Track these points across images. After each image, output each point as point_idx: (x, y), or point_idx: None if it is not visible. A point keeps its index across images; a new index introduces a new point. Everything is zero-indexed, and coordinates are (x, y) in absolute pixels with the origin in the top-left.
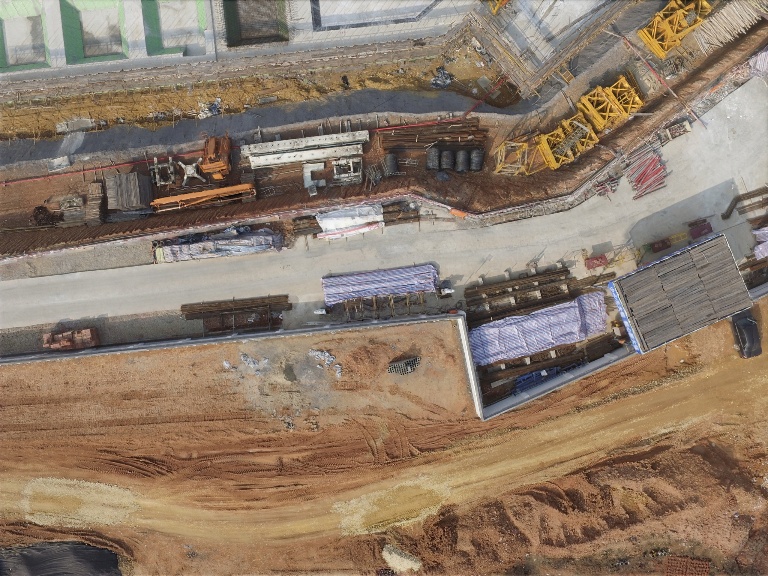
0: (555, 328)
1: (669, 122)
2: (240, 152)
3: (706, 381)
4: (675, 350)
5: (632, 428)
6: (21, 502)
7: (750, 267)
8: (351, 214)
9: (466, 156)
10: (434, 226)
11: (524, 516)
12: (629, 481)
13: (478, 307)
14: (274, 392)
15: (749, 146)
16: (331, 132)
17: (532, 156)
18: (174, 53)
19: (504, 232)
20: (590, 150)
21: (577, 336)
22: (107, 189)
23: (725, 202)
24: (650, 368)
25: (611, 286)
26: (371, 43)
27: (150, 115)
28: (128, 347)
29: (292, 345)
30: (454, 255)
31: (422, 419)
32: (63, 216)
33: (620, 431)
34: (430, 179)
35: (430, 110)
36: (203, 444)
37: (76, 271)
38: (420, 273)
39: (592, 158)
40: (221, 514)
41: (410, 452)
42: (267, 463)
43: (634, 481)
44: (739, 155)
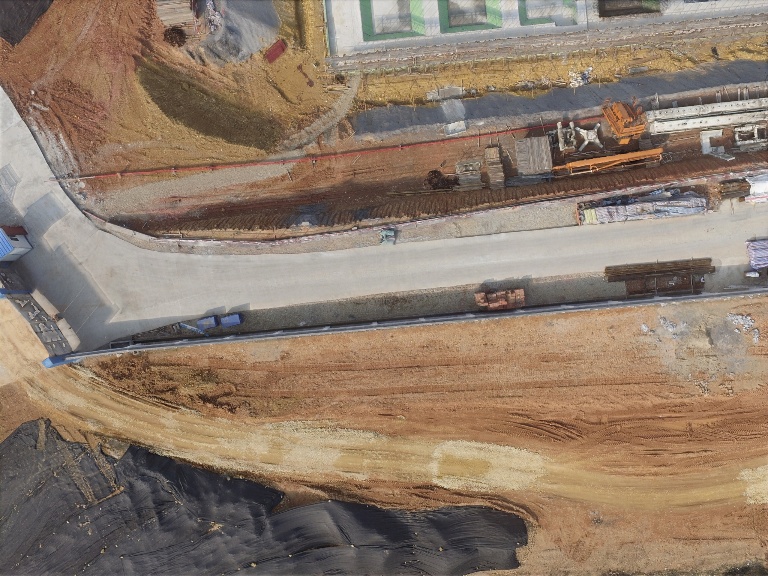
0: None
1: None
2: (637, 118)
3: None
4: None
5: None
6: (429, 465)
7: None
8: None
9: None
10: None
11: None
12: None
13: None
14: (690, 356)
15: None
16: (728, 99)
17: None
18: (546, 23)
19: None
20: None
21: None
22: (517, 152)
23: None
24: None
25: None
26: (741, 15)
27: (519, 84)
28: (569, 307)
29: (710, 309)
30: None
31: None
32: (458, 180)
33: None
34: None
35: None
36: (615, 408)
37: (501, 232)
38: None
39: None
40: (629, 480)
41: None
42: (676, 428)
43: None
44: None
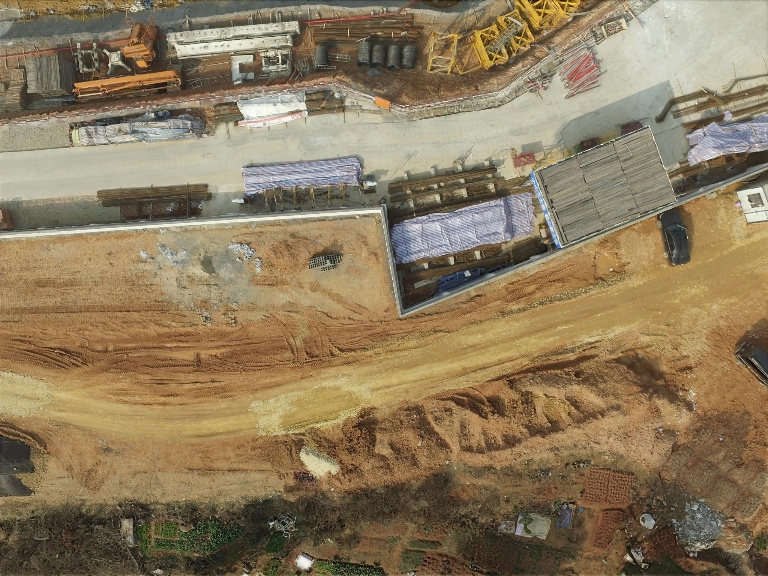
0: (480, 227)
1: (604, 18)
2: (167, 42)
3: (634, 290)
4: (605, 258)
5: (557, 336)
6: None
7: (683, 173)
8: (273, 101)
9: (397, 51)
10: (359, 118)
11: (444, 421)
12: (551, 388)
13: (403, 204)
14: (192, 285)
15: (686, 47)
16: None
17: (467, 55)
18: None
19: (431, 127)
20: (526, 51)
21: (502, 236)
22: (27, 72)
23: (660, 105)
24: (578, 275)
25: (532, 177)
26: None
27: (81, 7)
28: (39, 228)
29: (211, 237)
30: (379, 149)
31: (343, 318)
32: None
33: (545, 338)
34: (360, 73)
35: (364, 5)
36: (119, 336)
37: None
38: (343, 165)
39: (526, 56)
40: (136, 409)
41: (330, 352)
42: (184, 358)
43: (556, 388)
44: (676, 56)
